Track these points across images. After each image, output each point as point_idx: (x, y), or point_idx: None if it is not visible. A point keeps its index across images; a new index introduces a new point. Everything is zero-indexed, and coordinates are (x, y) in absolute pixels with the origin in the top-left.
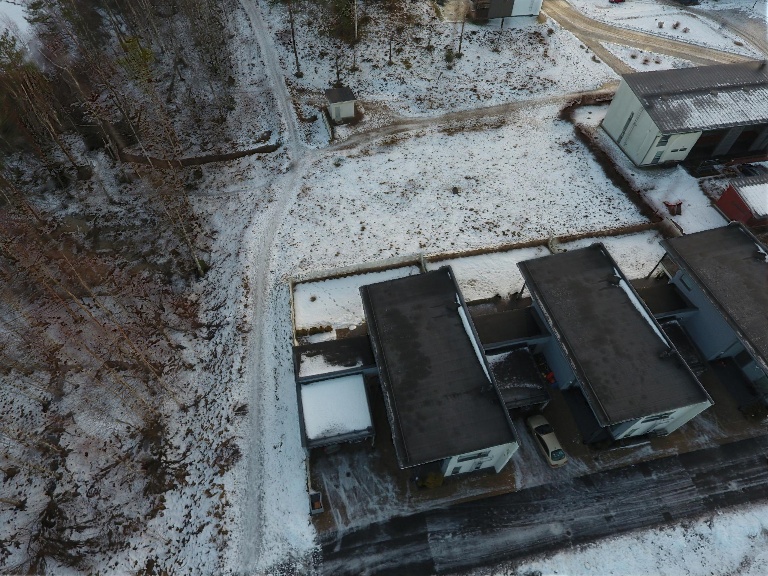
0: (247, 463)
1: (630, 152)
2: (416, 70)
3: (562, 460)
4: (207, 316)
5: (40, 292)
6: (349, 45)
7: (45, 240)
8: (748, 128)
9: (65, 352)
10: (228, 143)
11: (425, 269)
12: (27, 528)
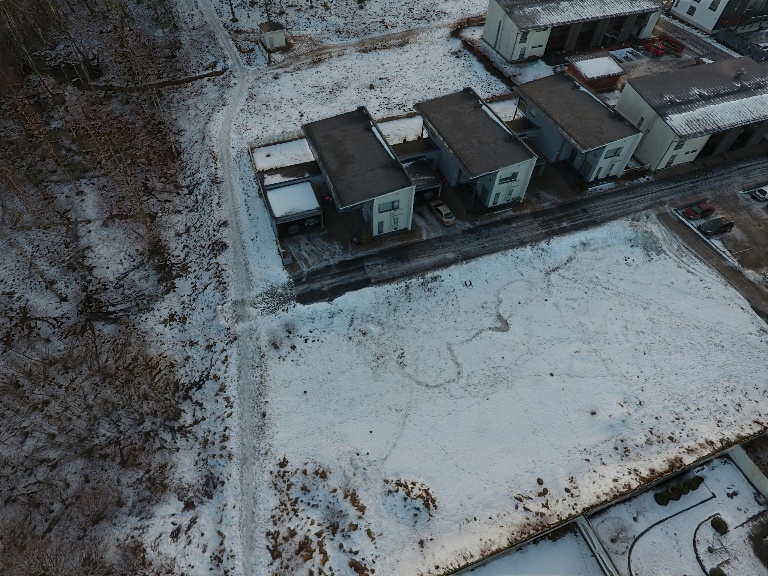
0: (233, 249)
1: (503, 52)
2: (334, 11)
3: (452, 218)
4: (185, 181)
5: (41, 180)
6: None
7: (36, 147)
8: (586, 28)
9: (74, 213)
10: (181, 72)
11: None
12: (72, 310)
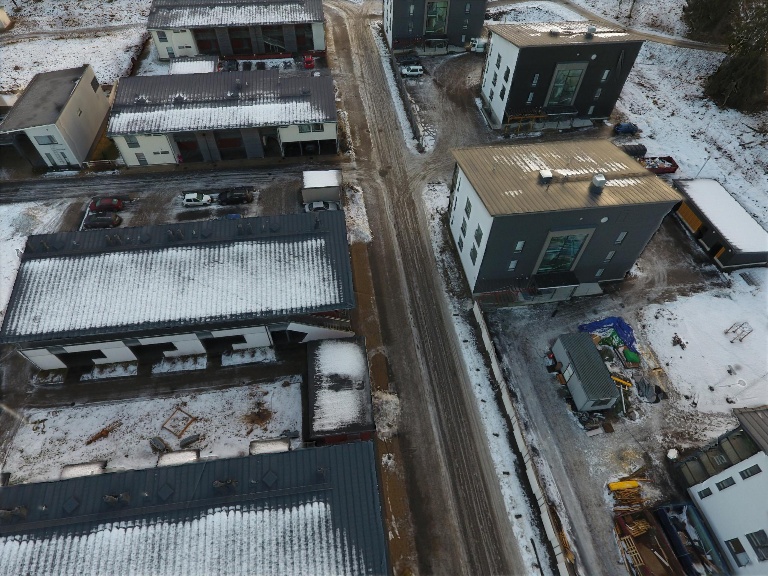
0: None
1: None
2: (84, 2)
3: None
4: None
5: None
6: None
7: None
8: (245, 35)
9: None
10: None
11: None
12: None
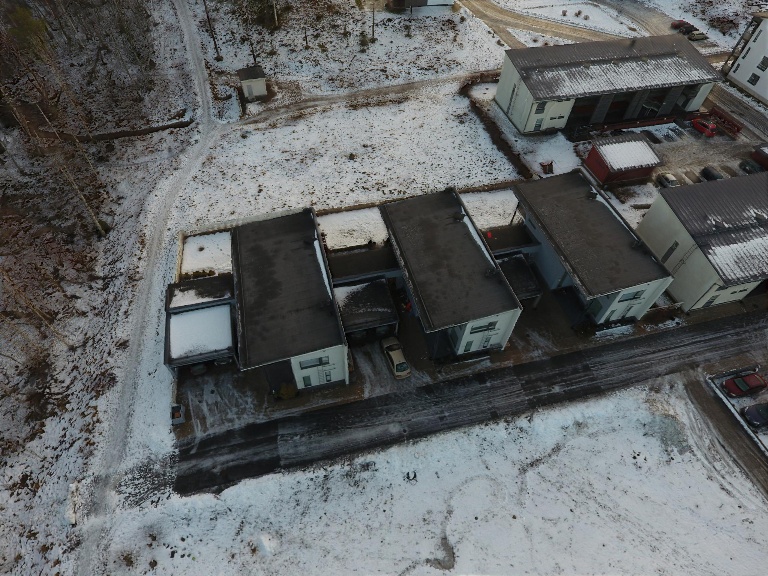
0: (121, 388)
1: (516, 121)
2: (331, 53)
3: (405, 371)
4: (104, 270)
5: None
6: (270, 31)
7: None
8: (620, 98)
9: None
10: (143, 120)
11: None
12: None
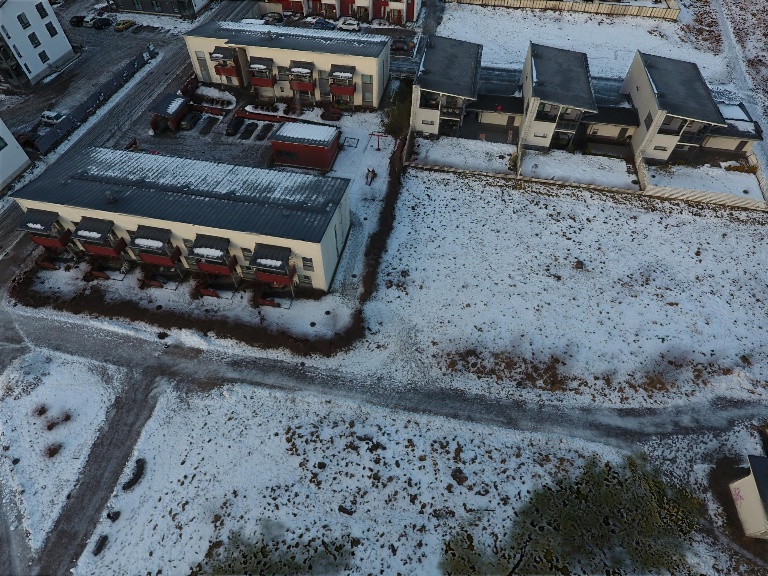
0: (764, 135)
1: None
2: None
3: None
4: None
5: None
6: None
7: None
8: None
9: None
10: None
11: (641, 187)
12: None
